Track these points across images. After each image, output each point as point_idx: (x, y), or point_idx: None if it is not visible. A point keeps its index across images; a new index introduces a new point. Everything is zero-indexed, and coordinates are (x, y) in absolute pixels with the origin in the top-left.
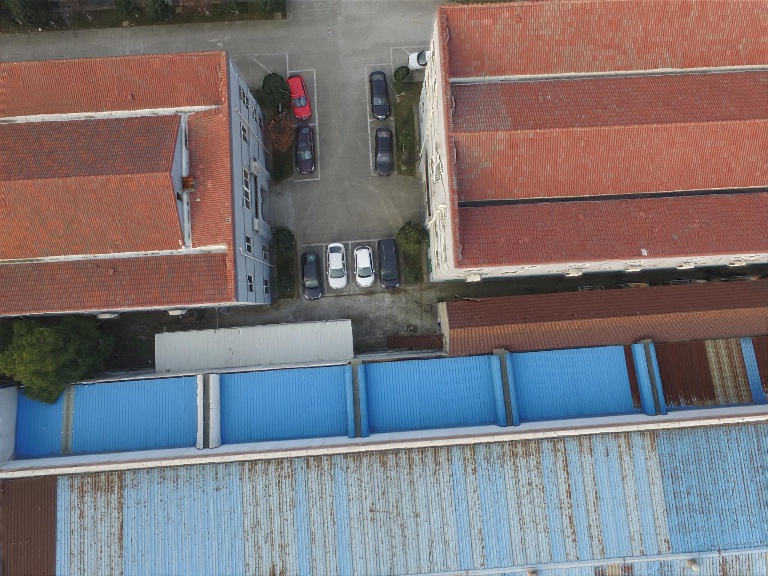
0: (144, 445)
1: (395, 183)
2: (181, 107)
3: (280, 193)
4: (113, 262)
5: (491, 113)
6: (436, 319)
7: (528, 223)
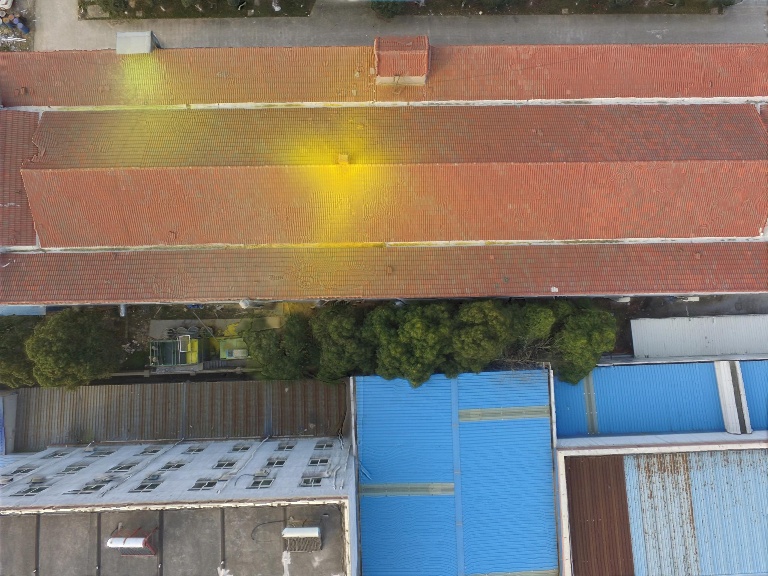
0: (669, 428)
1: None
2: (753, 96)
3: None
4: (695, 246)
5: None
6: None
7: None
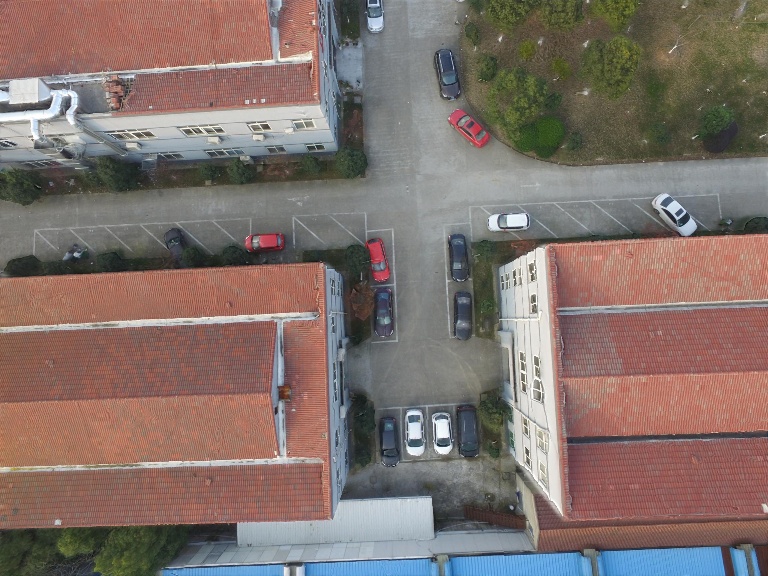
0: None
1: (473, 346)
2: (277, 313)
3: (358, 355)
4: (210, 471)
5: (601, 353)
6: (515, 488)
7: (637, 463)
